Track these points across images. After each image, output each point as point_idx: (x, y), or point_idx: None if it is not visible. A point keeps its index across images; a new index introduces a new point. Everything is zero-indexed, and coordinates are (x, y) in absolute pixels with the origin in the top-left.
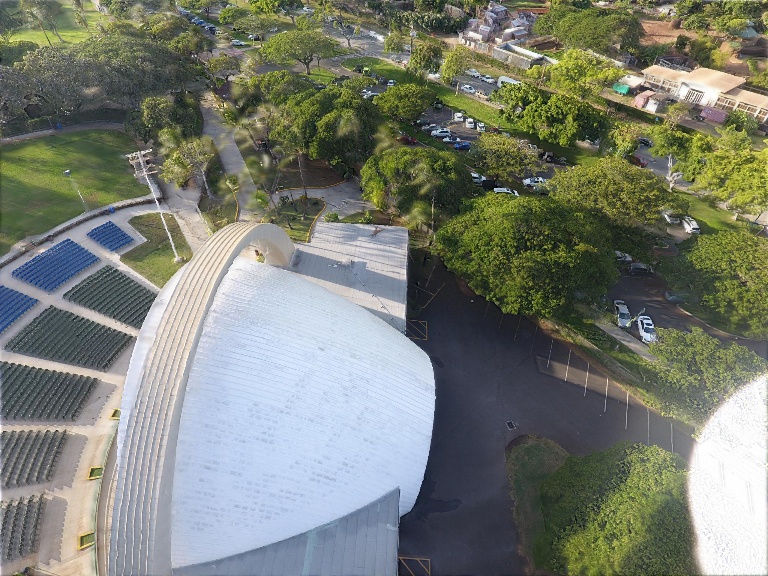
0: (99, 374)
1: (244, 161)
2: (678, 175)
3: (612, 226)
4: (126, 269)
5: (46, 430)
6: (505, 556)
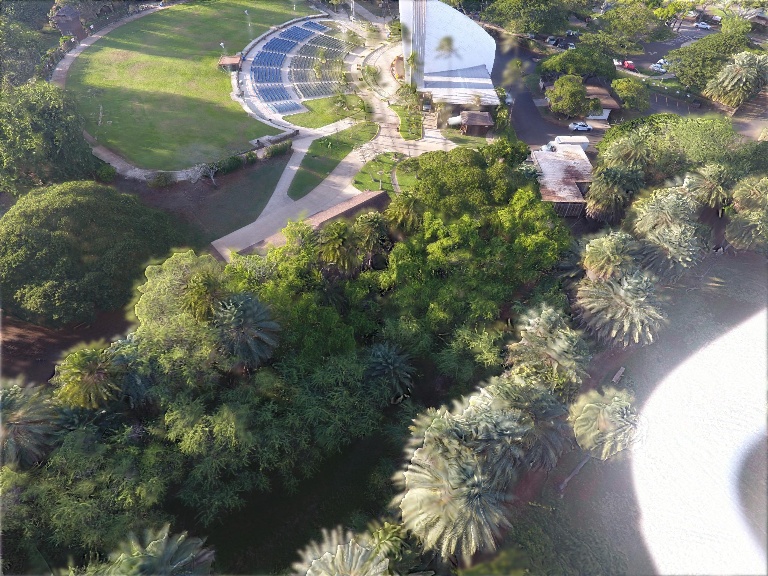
0: None
1: (361, 6)
2: (604, 4)
3: (566, 7)
4: None
5: None
6: (524, 92)
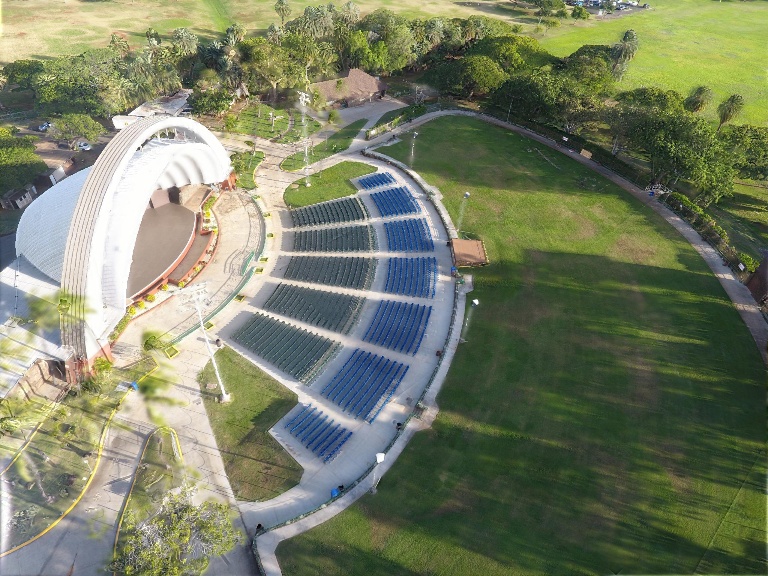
0: (285, 283)
1: None
2: None
3: None
4: (287, 382)
5: (308, 253)
6: None
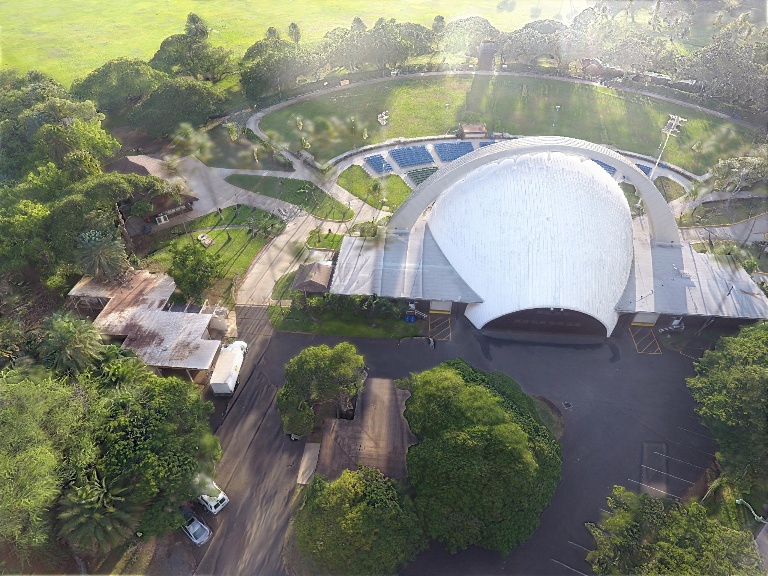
0: None
1: None
2: None
3: None
4: None
5: None
6: None
